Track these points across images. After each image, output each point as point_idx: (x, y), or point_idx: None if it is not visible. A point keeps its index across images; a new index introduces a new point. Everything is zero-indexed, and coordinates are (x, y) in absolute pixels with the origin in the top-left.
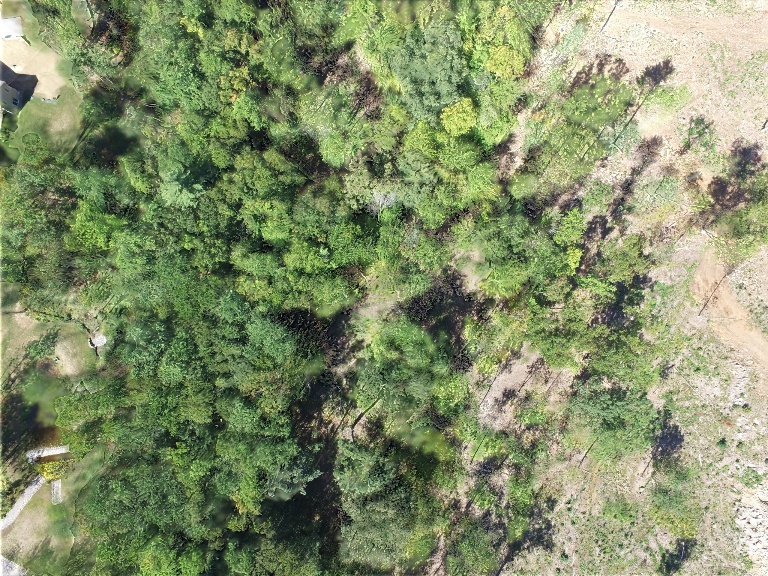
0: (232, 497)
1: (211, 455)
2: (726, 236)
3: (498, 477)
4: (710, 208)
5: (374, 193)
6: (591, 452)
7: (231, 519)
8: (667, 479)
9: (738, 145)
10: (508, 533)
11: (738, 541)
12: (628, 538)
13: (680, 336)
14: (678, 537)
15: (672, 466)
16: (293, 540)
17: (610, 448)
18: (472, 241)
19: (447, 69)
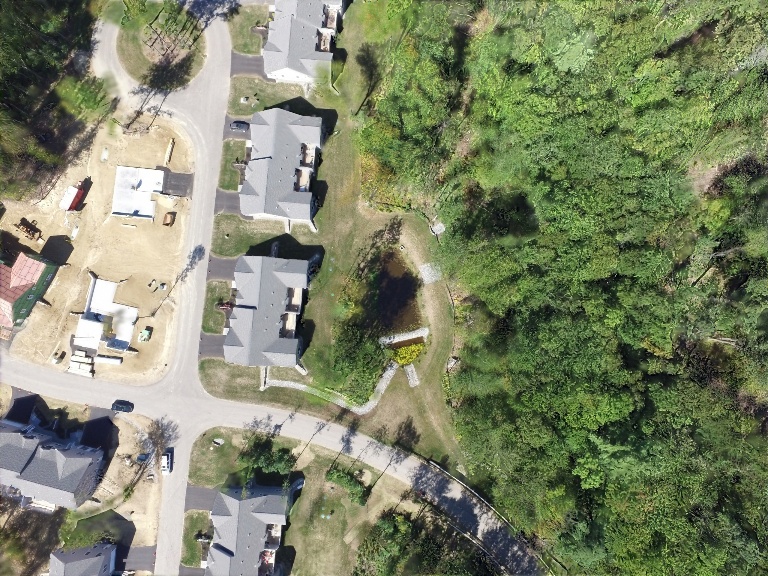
0: (642, 343)
1: (616, 306)
2: None
3: None
4: None
5: (752, 49)
6: None
7: (650, 362)
8: None
9: None
10: None
11: None
12: None
13: None
14: None
15: None
16: None
17: None
18: None
19: None
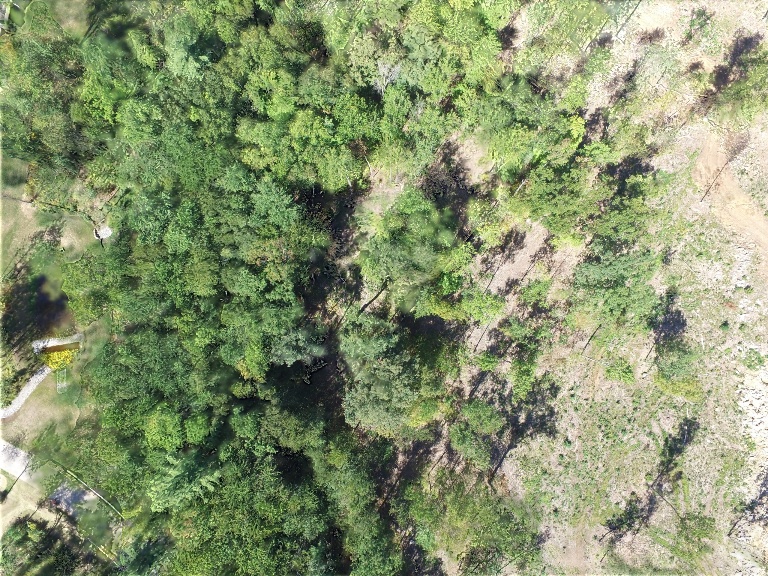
0: (237, 365)
1: (216, 325)
2: (728, 124)
3: (501, 365)
4: (712, 96)
5: (378, 65)
6: (594, 339)
7: (236, 385)
8: (670, 364)
9: (739, 35)
10: (511, 421)
11: (741, 423)
12: (631, 423)
13: (682, 222)
14: (681, 421)
15: (675, 350)
16: (297, 411)
17: (613, 334)
18: (475, 131)
19: None
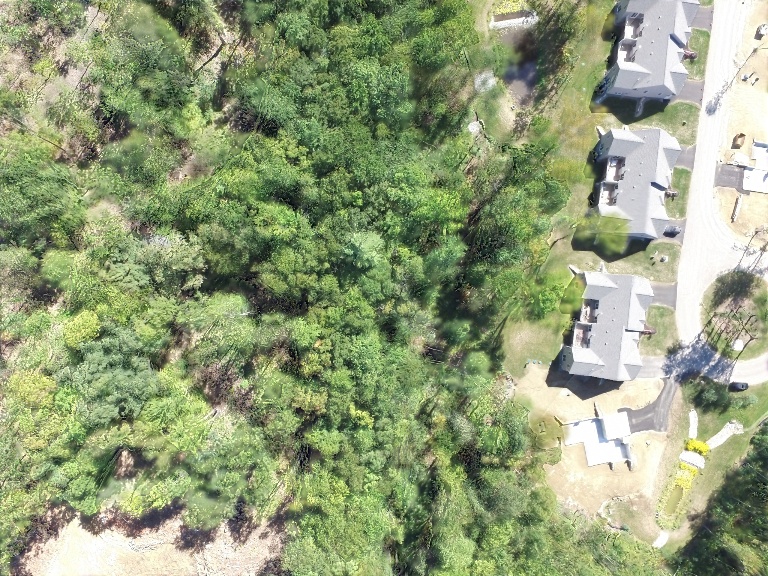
0: None
1: None
2: None
3: None
4: None
5: None
6: None
7: None
8: None
9: None
10: None
11: None
12: None
13: None
14: None
15: None
16: None
17: None
18: None
19: (88, 374)
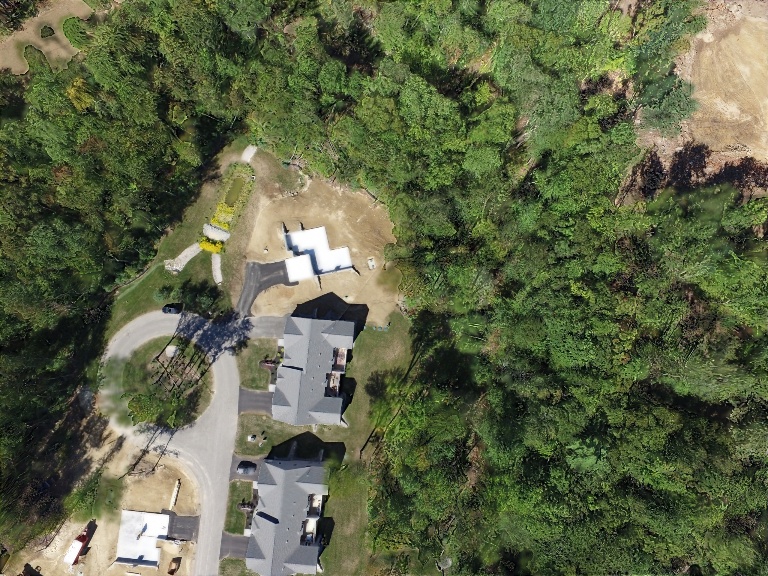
0: None
1: None
2: None
3: None
4: None
5: None
6: None
7: None
8: None
9: None
10: None
11: None
12: None
13: None
14: None
15: None
16: None
17: None
18: None
19: None
